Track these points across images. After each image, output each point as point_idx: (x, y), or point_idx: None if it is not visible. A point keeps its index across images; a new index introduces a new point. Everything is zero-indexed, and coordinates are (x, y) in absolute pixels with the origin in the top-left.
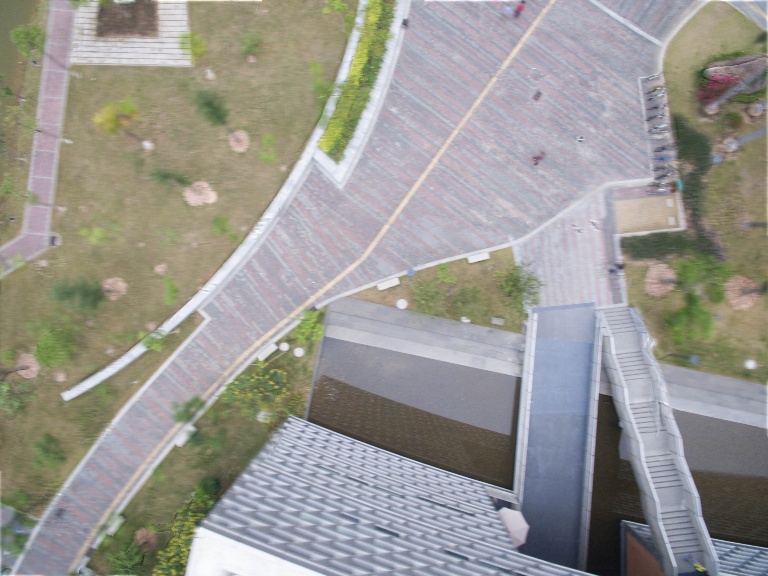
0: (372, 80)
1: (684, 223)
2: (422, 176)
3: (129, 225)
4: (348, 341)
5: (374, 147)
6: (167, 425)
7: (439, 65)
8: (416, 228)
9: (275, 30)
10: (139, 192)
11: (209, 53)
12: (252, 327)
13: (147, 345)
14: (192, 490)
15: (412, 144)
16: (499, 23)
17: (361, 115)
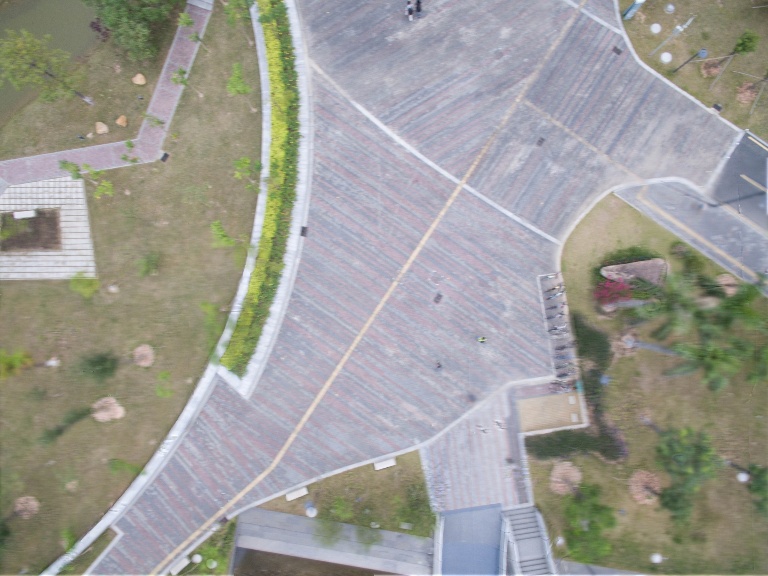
0: (272, 295)
1: (587, 419)
2: (327, 383)
3: (38, 443)
4: (260, 550)
5: (278, 357)
6: None
7: (340, 272)
8: (323, 435)
9: (176, 242)
10: (47, 410)
11: (112, 265)
12: (164, 540)
13: (59, 567)
14: None
15: (316, 352)
16: (398, 227)
17: (262, 331)
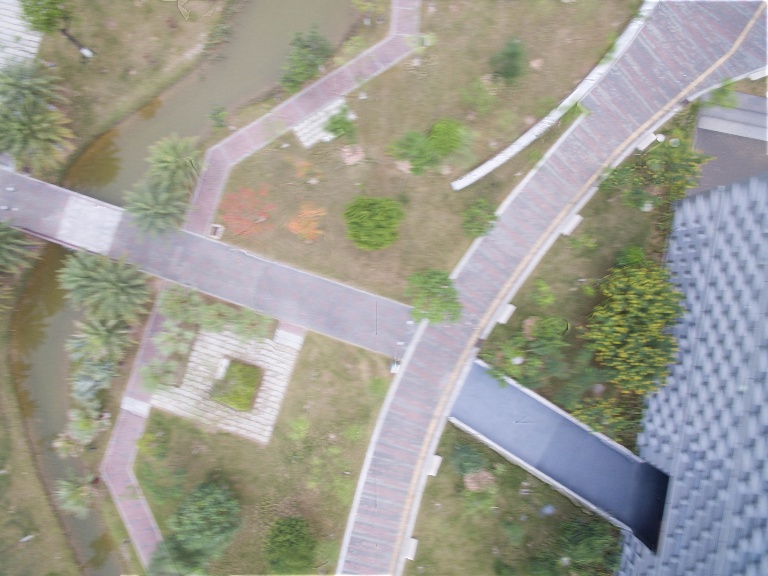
0: None
1: None
2: None
3: (504, 22)
4: (720, 132)
5: None
6: (550, 216)
7: None
8: None
9: None
10: None
11: None
12: (628, 119)
13: (535, 134)
14: (577, 278)
15: None
16: None
17: None
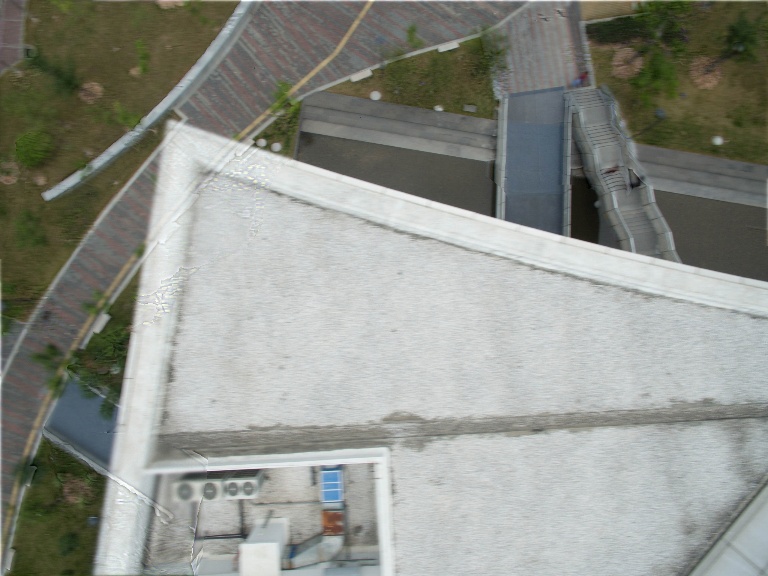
0: None
1: (647, 8)
2: None
3: (103, 31)
4: (324, 135)
5: None
6: (149, 224)
7: None
8: (386, 22)
9: None
10: None
11: None
12: (229, 125)
13: (125, 143)
14: None
15: None
16: None
17: None
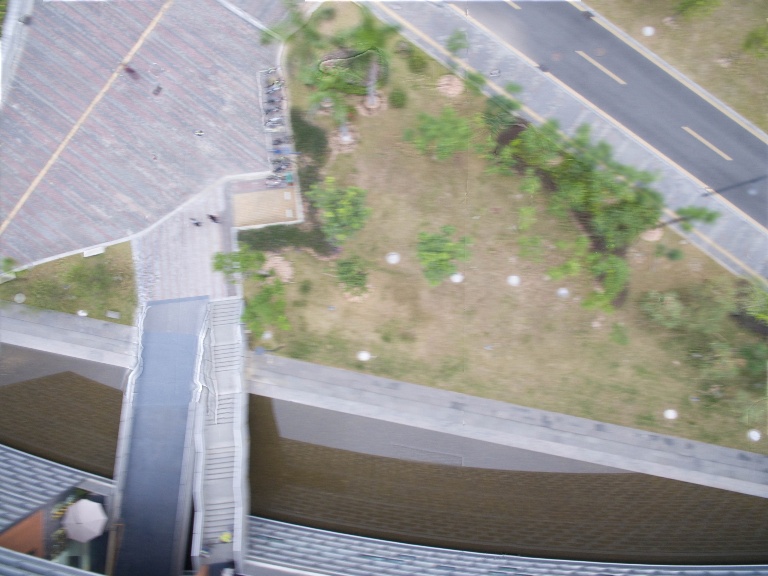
0: None
1: (301, 216)
2: (42, 171)
3: None
4: None
5: None
6: None
7: (60, 61)
8: (36, 223)
9: None
10: None
11: None
12: None
13: None
14: None
15: (33, 140)
16: (120, 19)
17: None
